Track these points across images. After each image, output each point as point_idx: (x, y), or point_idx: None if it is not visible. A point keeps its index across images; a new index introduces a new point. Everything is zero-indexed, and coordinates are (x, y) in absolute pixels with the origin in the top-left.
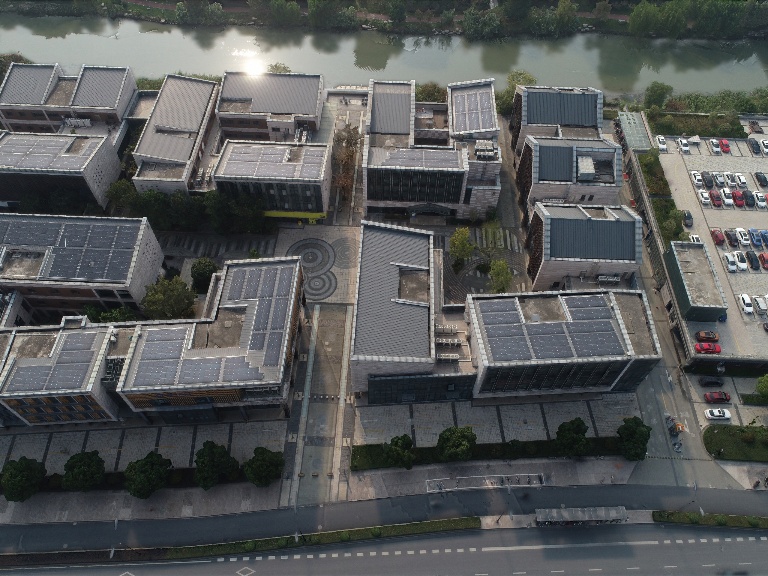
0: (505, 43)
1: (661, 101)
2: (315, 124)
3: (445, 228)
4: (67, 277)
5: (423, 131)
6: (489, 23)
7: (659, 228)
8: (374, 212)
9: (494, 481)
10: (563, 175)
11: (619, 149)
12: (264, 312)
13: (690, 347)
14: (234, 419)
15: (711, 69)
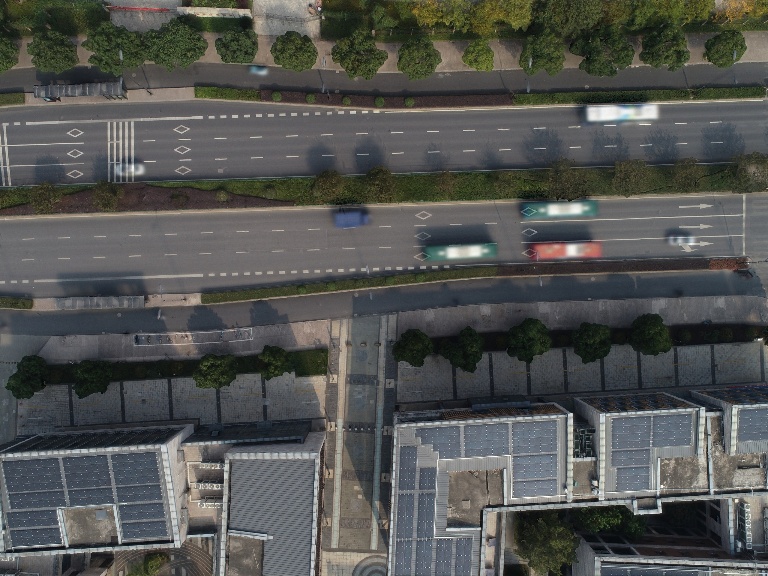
0: None
1: None
2: None
3: None
4: (675, 571)
5: None
6: None
7: None
8: None
9: (184, 339)
10: None
11: None
12: (425, 519)
13: None
14: (453, 404)
15: None
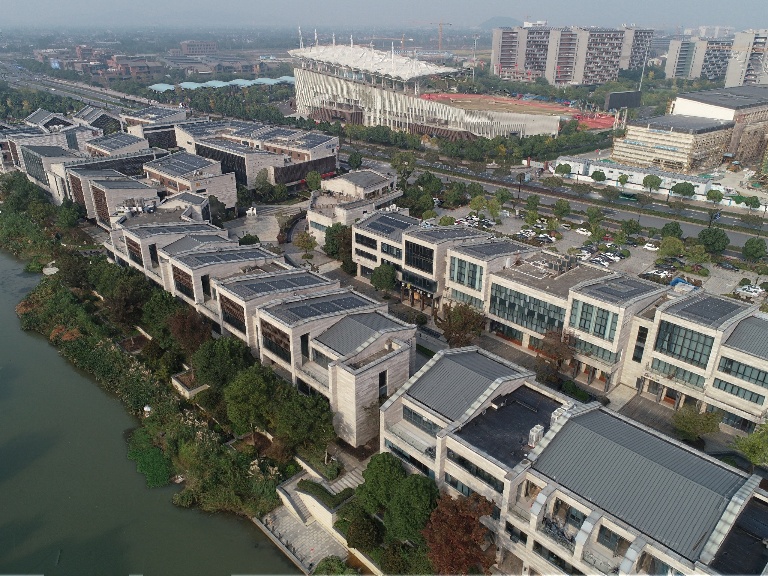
0: None
1: None
2: None
3: None
4: None
5: None
6: None
7: None
8: None
9: None
10: None
11: None
12: None
13: None
14: None
15: None
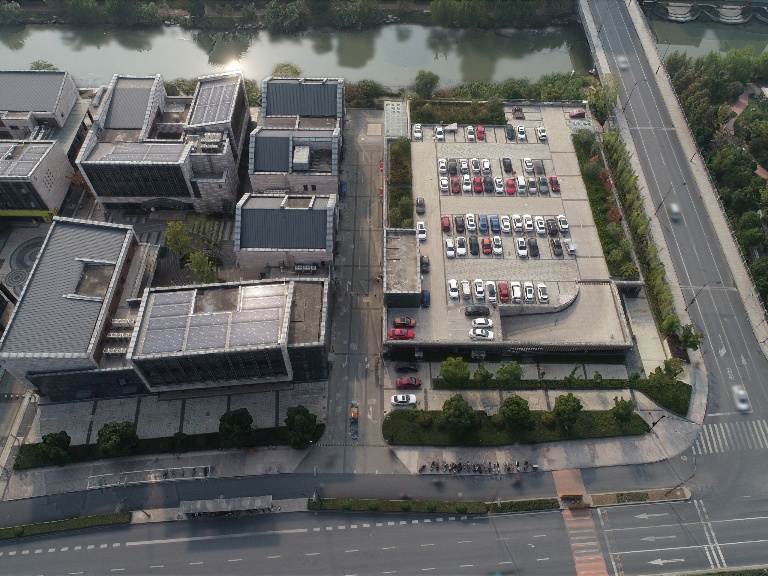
0: (306, 36)
1: (428, 90)
2: (56, 121)
3: (184, 222)
4: None
5: (166, 125)
6: (290, 16)
7: (389, 216)
8: (115, 208)
9: (158, 475)
10: (280, 165)
11: (335, 138)
12: None
13: (383, 334)
14: None
15: (506, 57)
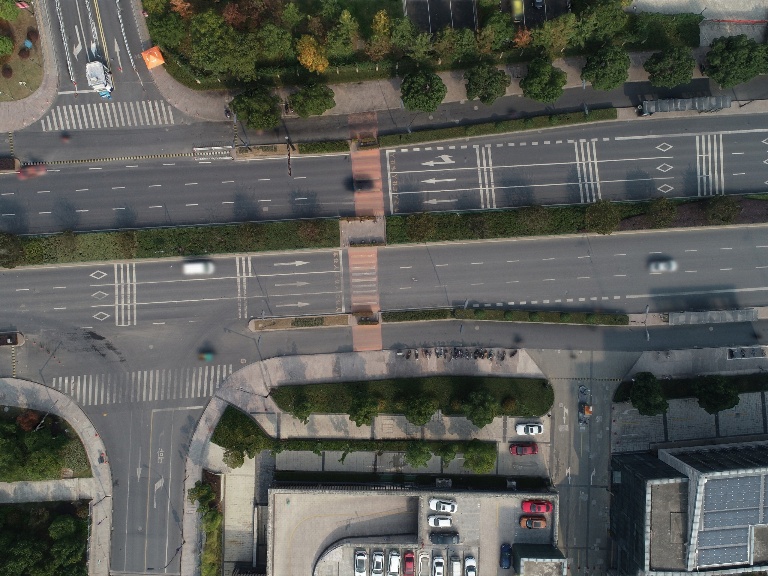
0: None
1: None
2: None
3: None
4: None
5: None
6: None
7: None
8: None
9: None
10: None
11: None
12: None
13: None
14: None
15: None
